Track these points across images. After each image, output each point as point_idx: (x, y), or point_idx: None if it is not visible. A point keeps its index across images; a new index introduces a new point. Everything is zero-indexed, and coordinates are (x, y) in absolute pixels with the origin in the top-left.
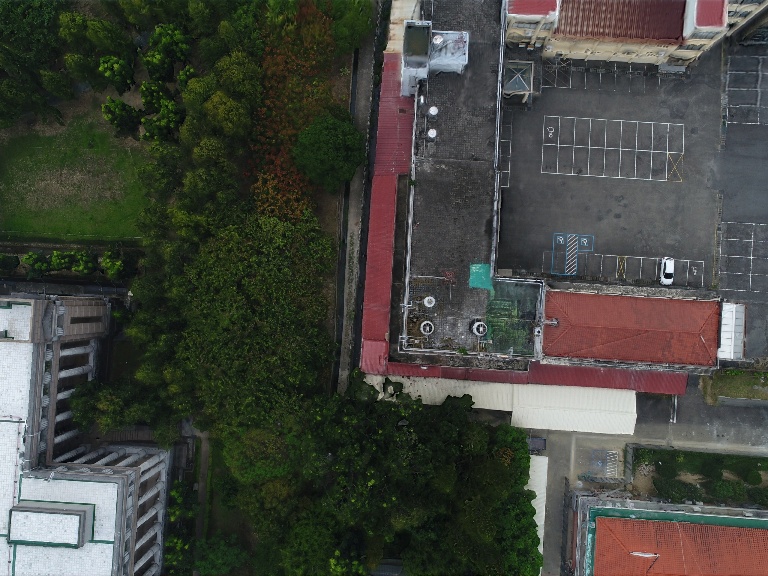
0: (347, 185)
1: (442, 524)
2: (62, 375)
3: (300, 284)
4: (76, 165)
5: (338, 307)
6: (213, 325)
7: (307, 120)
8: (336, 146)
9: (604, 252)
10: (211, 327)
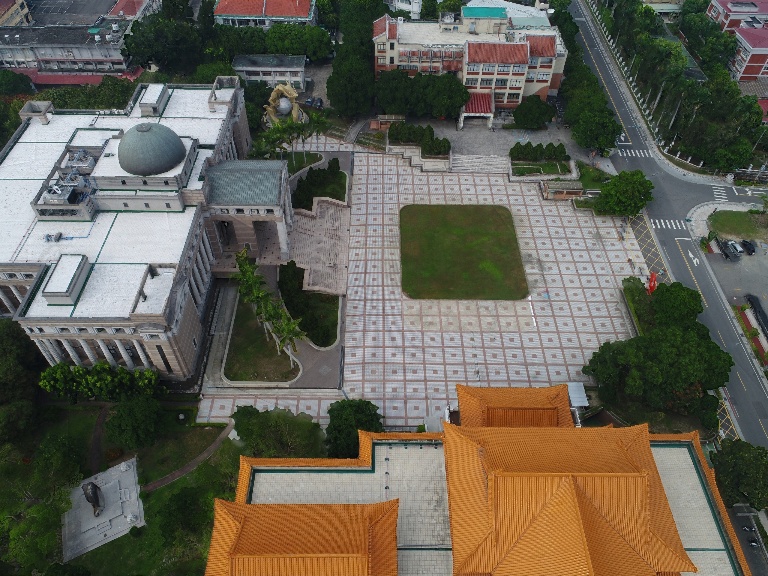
0: None
1: None
2: None
3: None
4: None
5: None
6: None
7: None
8: None
9: None
10: None
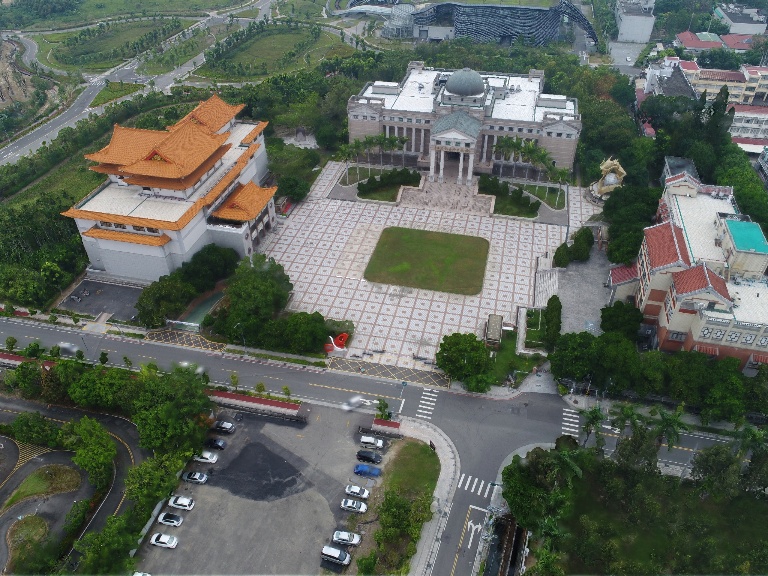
0: None
1: None
2: None
3: None
4: None
5: None
6: None
7: None
8: None
9: None
10: None
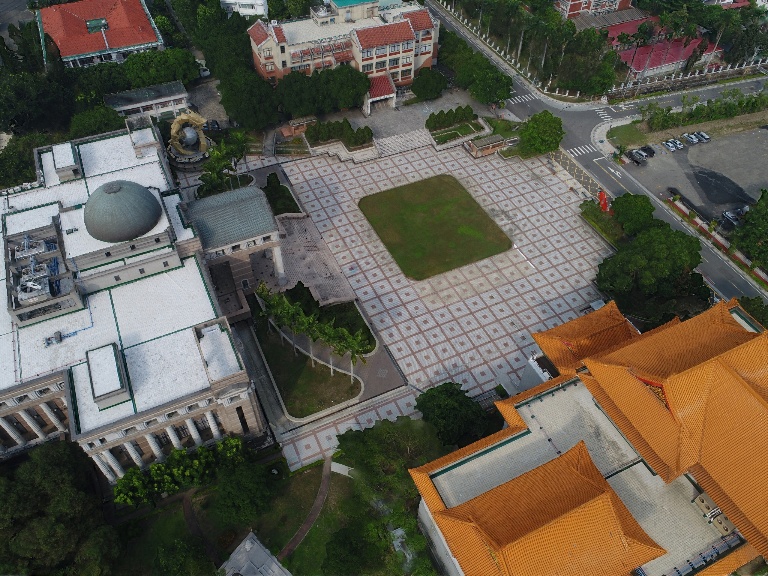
0: None
1: None
2: None
3: None
4: None
5: None
6: None
7: None
8: None
9: None
10: None
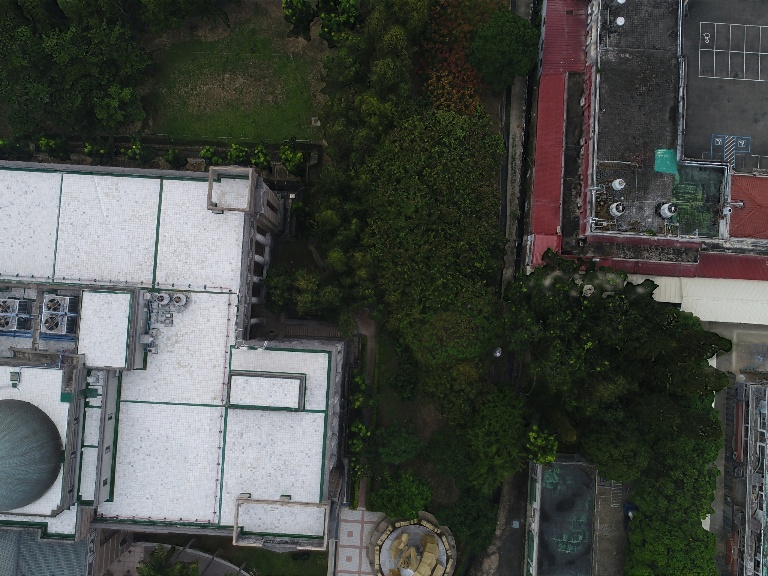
0: (508, 89)
1: (626, 406)
2: (256, 257)
3: (477, 176)
4: (238, 70)
5: (500, 208)
6: (396, 214)
7: (482, 17)
8: (516, 39)
9: (761, 153)
10: (394, 216)
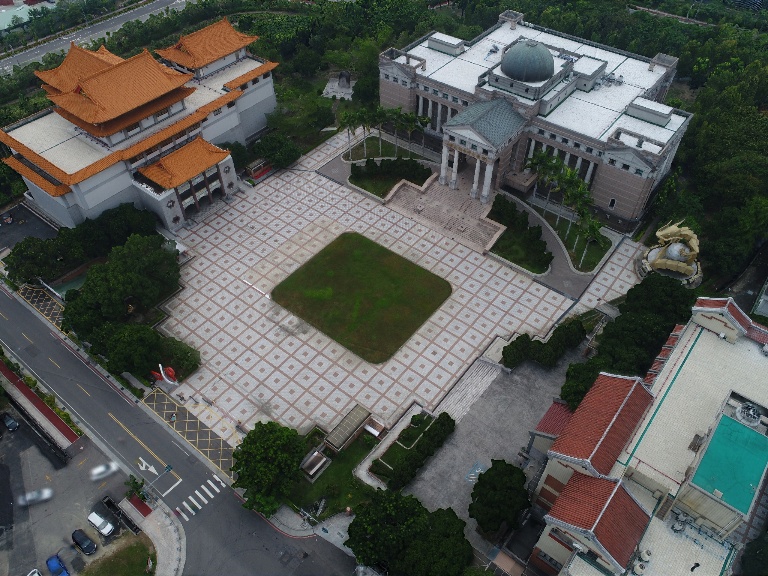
0: None
1: None
2: None
3: None
4: None
5: None
6: None
7: None
8: None
9: None
10: None
